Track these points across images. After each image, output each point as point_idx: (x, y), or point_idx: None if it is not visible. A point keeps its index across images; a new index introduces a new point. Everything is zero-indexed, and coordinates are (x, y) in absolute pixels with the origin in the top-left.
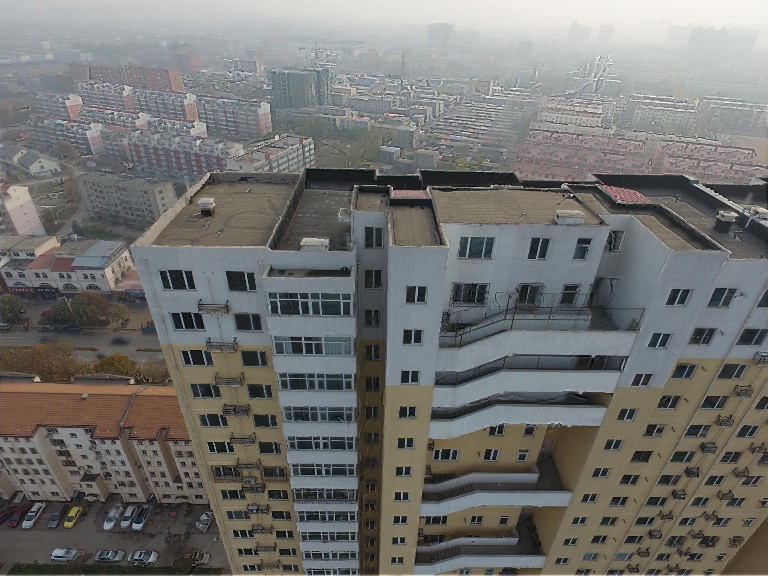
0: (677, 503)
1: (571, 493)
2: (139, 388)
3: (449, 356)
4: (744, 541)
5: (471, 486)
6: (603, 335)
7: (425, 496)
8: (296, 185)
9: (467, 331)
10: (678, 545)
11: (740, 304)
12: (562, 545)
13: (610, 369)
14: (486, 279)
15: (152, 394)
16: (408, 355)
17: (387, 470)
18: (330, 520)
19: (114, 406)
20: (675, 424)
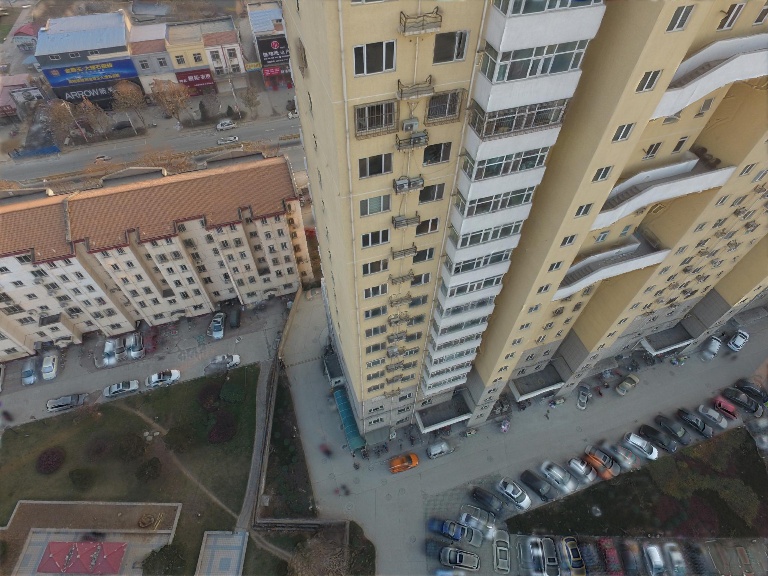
0: None
1: None
2: (66, 196)
3: None
4: None
5: (708, 65)
6: None
7: None
8: None
9: None
10: None
11: None
12: (764, 142)
13: None
14: None
15: (91, 196)
16: None
17: (663, 17)
18: (512, 171)
19: (45, 220)
20: None
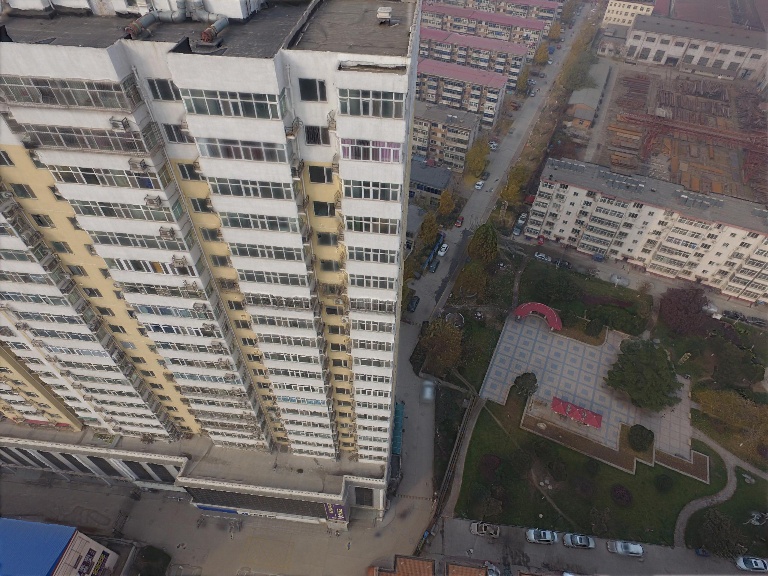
0: None
1: None
2: None
3: None
4: None
5: None
6: None
7: None
8: (292, 31)
9: None
10: None
11: None
12: None
13: None
14: None
15: None
16: None
17: None
18: None
19: None
20: None
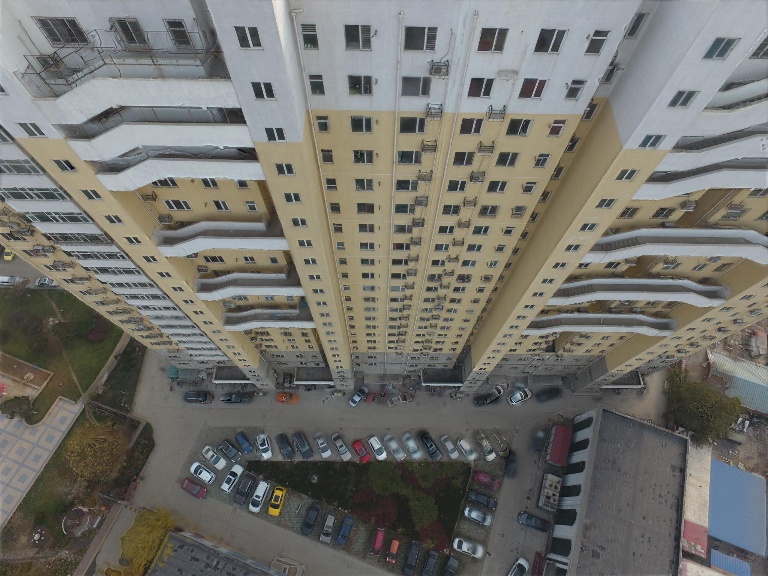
0: (420, 248)
1: (285, 239)
2: None
3: (50, 107)
4: (494, 278)
5: (206, 232)
6: (196, 84)
7: (170, 240)
8: None
9: (76, 78)
10: (438, 281)
11: (382, 46)
12: (309, 280)
13: (238, 122)
14: (67, 12)
15: None
16: (5, 106)
17: (96, 218)
18: (105, 258)
19: None
20: (380, 178)
